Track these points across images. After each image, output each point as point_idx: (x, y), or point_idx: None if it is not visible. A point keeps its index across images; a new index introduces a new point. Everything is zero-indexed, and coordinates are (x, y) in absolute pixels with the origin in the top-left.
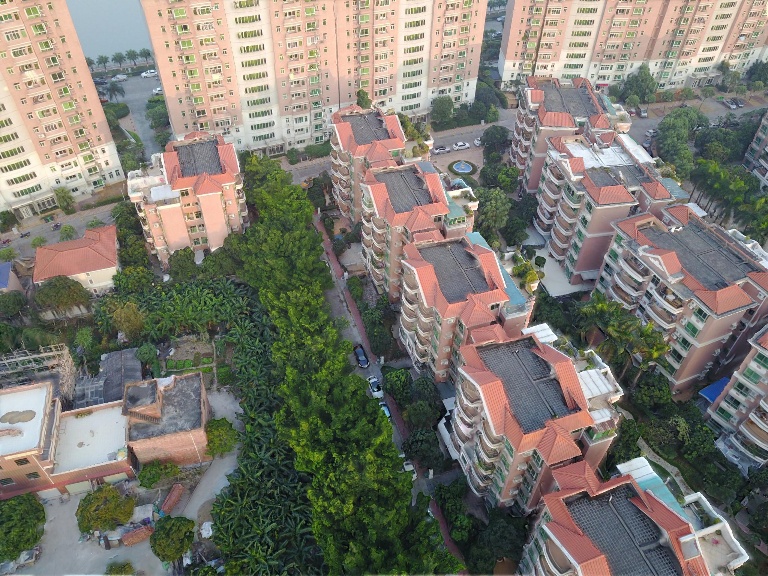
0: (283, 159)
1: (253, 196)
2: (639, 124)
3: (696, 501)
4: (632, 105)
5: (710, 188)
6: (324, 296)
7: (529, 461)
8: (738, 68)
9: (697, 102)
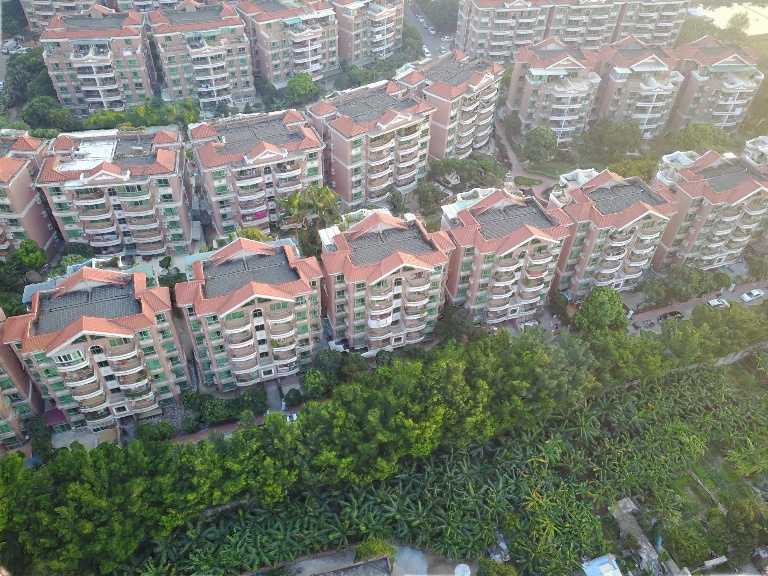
0: None
1: None
2: None
3: None
4: None
5: None
6: None
7: None
8: None
9: None
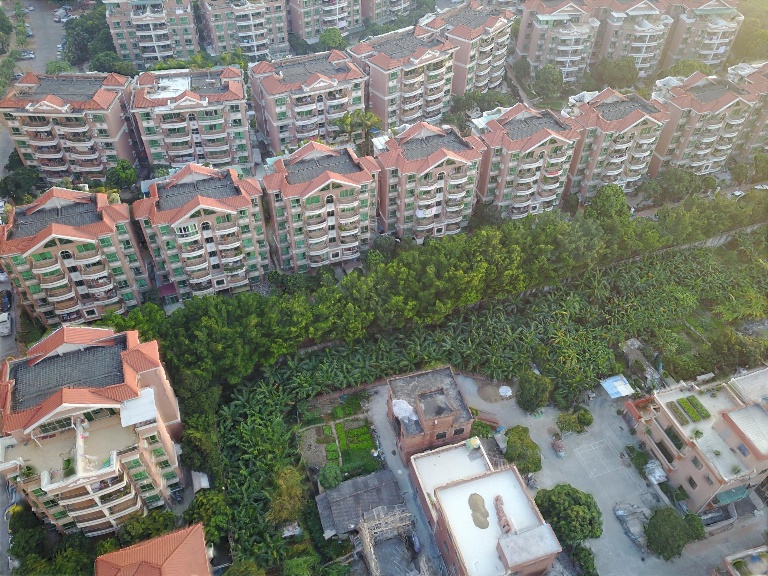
0: None
1: None
2: None
3: None
4: None
5: None
6: None
7: None
8: None
9: None
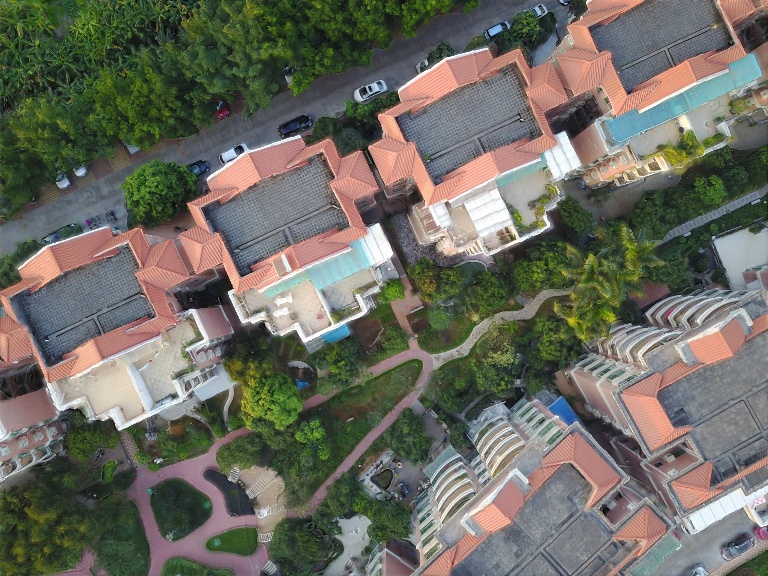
0: None
1: None
2: None
3: None
4: None
5: None
6: None
7: None
8: None
9: None
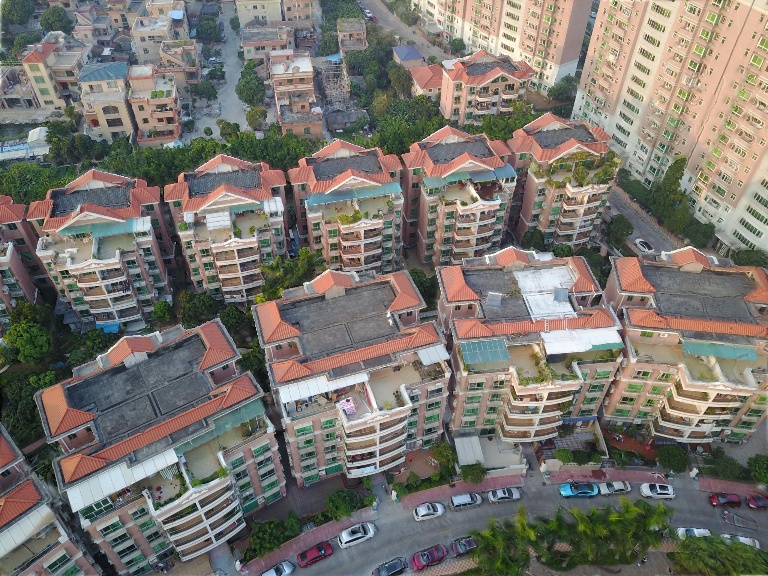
0: None
1: None
2: None
3: None
4: None
5: None
6: None
7: None
8: None
9: None
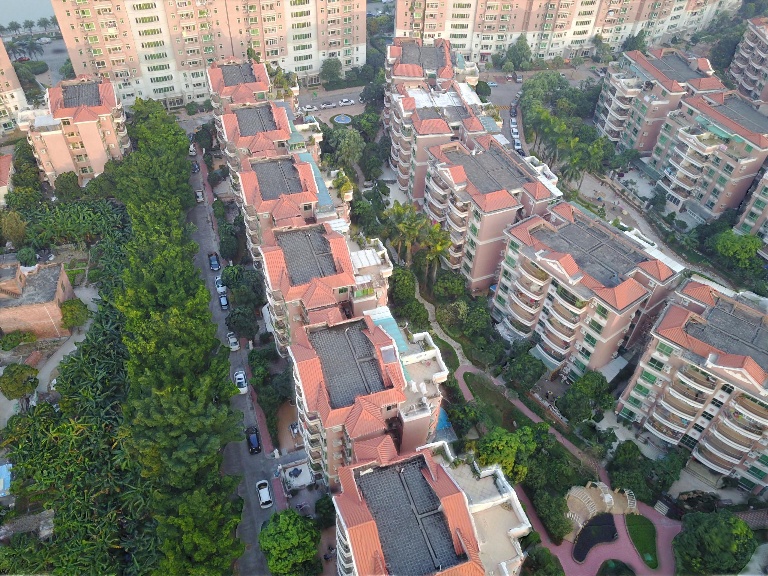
0: (183, 111)
1: (136, 132)
2: (513, 88)
3: (424, 338)
4: (507, 70)
5: (543, 133)
6: (194, 217)
7: (303, 314)
8: (612, 42)
9: (571, 71)
